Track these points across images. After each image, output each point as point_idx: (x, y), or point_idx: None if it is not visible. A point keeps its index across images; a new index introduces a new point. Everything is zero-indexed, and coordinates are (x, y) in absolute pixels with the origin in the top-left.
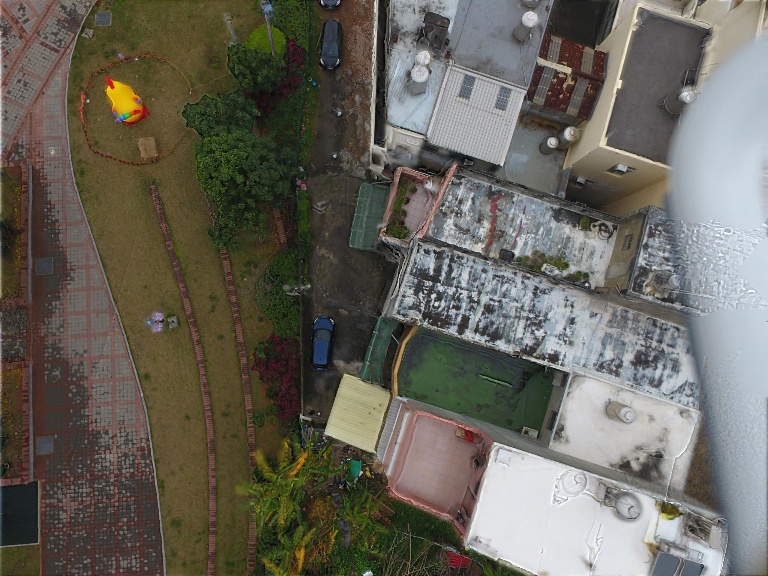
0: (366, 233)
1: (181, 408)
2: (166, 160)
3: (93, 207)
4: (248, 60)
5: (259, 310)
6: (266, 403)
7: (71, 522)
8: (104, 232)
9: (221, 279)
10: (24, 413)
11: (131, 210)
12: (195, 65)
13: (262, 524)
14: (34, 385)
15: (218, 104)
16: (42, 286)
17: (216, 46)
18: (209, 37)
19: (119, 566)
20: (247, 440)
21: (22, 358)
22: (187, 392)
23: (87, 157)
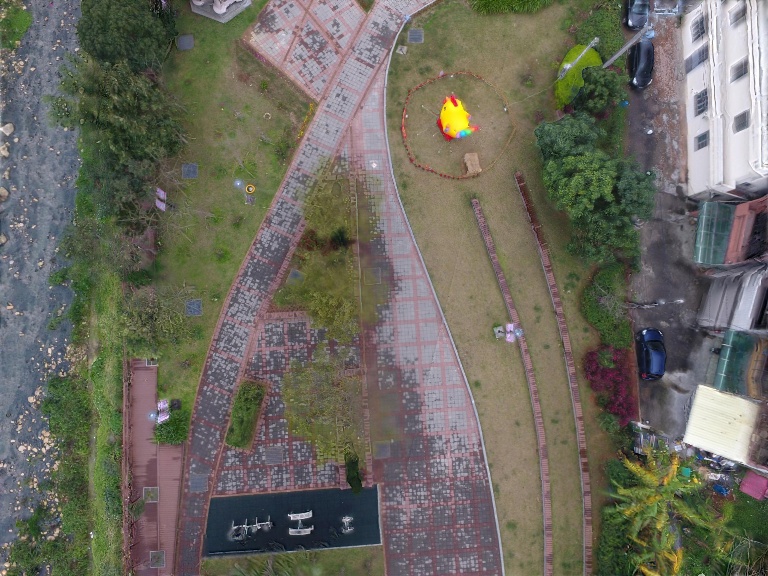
0: (715, 250)
1: (511, 415)
2: (486, 175)
3: (417, 219)
4: (616, 82)
5: (584, 321)
6: (595, 411)
7: (411, 524)
8: (429, 244)
9: (544, 291)
10: (366, 418)
11: (453, 223)
12: (509, 82)
13: (640, 528)
14: (369, 391)
15: (582, 124)
16: (371, 295)
17: (528, 64)
18: (521, 55)
19: (459, 566)
20: (577, 446)
21: (356, 365)
22: (516, 400)
23: (408, 171)
